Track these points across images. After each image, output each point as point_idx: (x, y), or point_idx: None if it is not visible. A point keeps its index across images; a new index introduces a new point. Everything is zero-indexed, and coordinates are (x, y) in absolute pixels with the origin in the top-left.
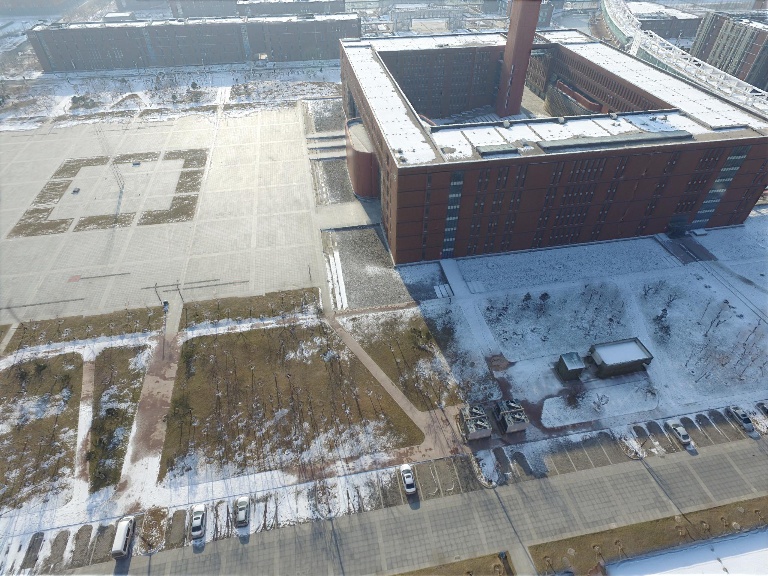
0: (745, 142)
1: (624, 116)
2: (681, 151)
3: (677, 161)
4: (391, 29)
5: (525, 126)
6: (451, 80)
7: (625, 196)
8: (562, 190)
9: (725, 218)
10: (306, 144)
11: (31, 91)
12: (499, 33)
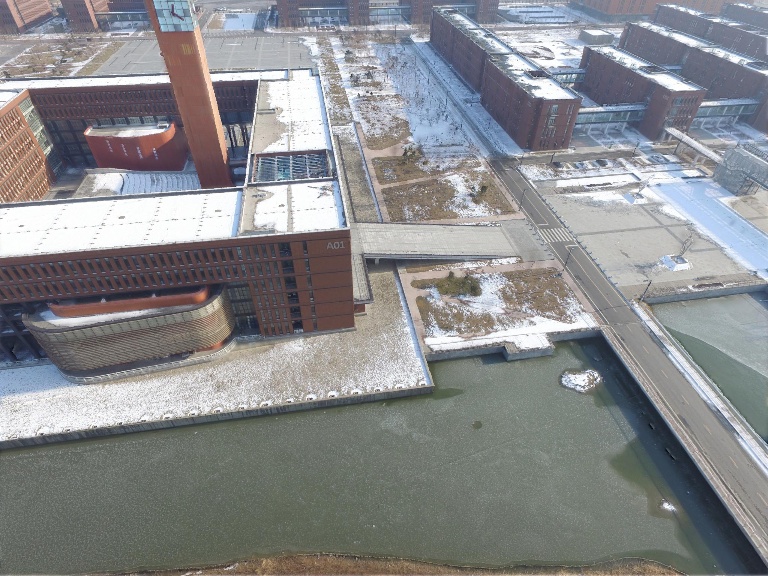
0: None
1: None
2: None
3: None
4: None
5: None
6: None
7: None
8: None
9: None
10: (238, 127)
11: (384, 45)
12: None
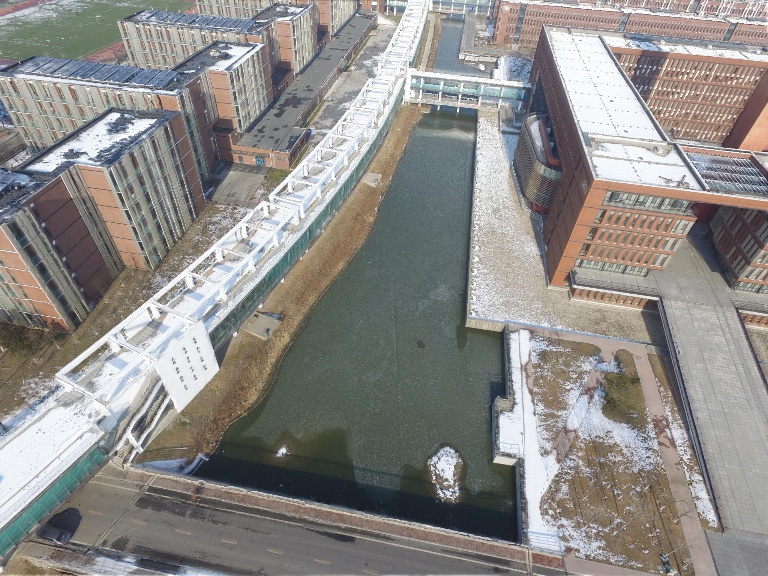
0: None
1: None
2: None
3: None
4: None
5: None
6: None
7: None
8: None
9: None
10: None
11: None
12: None
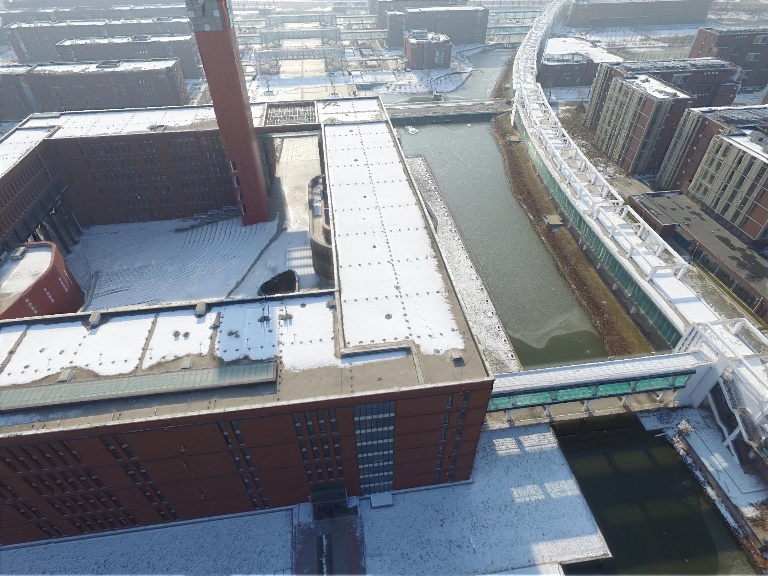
0: (374, 398)
1: (224, 307)
2: (234, 419)
3: (241, 431)
4: (255, 72)
5: (16, 334)
6: (176, 172)
7: (175, 475)
8: (17, 481)
9: (426, 477)
10: None
11: None
12: (266, 103)
